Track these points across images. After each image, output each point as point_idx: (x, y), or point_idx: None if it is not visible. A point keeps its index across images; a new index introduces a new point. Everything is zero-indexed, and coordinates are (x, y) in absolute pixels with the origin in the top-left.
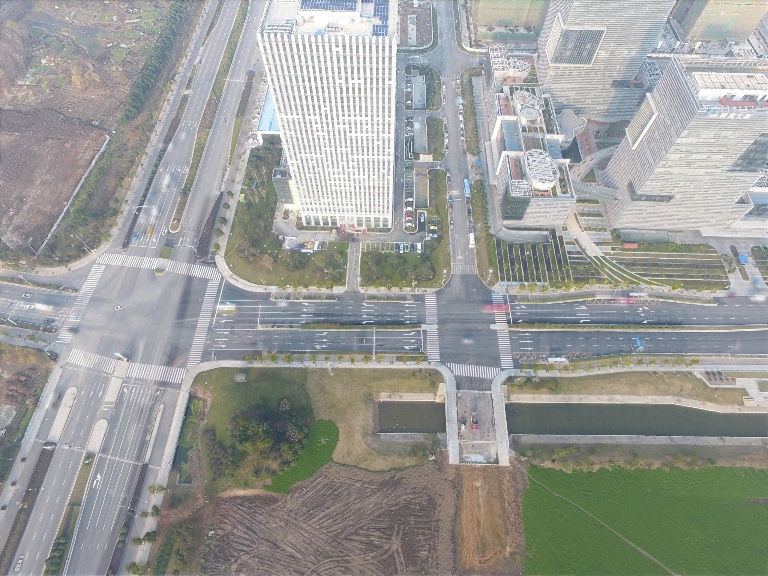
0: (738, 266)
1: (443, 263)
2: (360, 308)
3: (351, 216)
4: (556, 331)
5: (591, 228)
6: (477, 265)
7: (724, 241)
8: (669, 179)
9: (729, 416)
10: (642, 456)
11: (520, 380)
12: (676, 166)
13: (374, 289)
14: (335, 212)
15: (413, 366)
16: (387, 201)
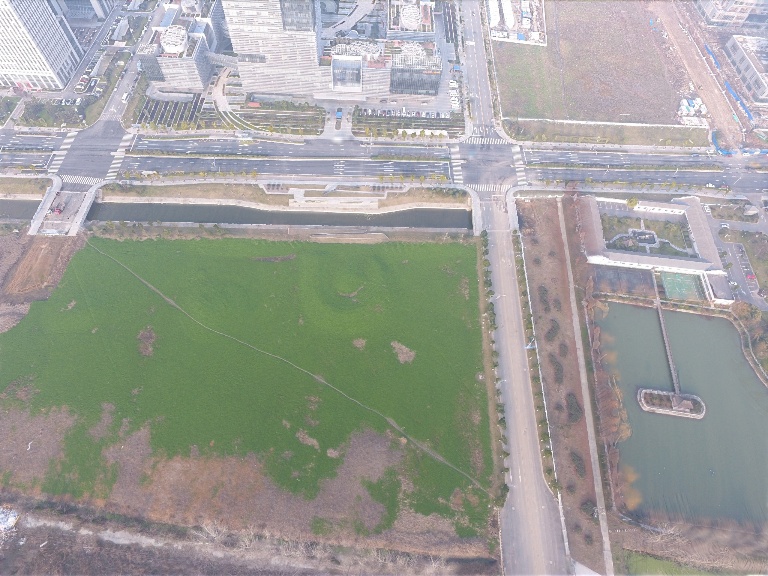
0: (336, 120)
1: (95, 113)
2: (8, 140)
3: (20, 74)
4: (164, 157)
5: (231, 93)
6: (123, 115)
7: (335, 105)
8: (246, 37)
9: (275, 213)
10: None
11: (113, 185)
12: (240, 22)
13: (27, 128)
14: (4, 69)
15: (32, 176)
16: (39, 57)
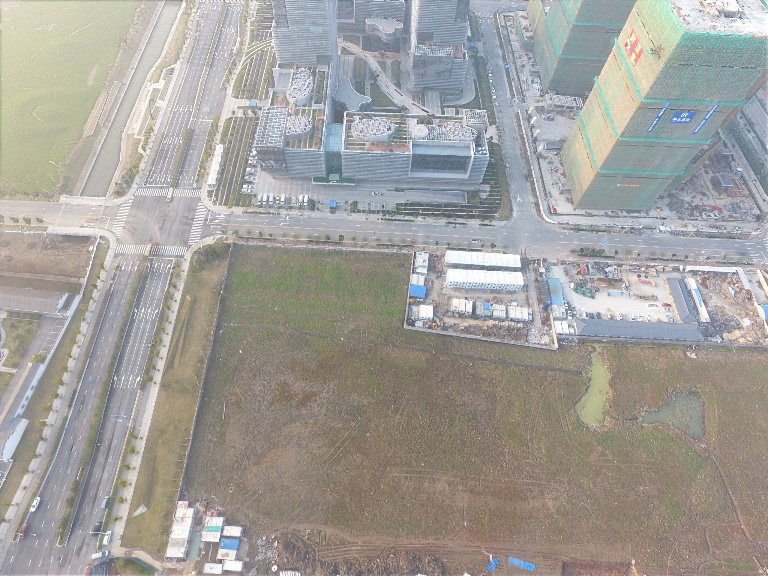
0: None
1: None
2: None
3: None
4: None
5: None
6: None
7: None
8: None
9: None
10: (131, 23)
11: None
12: None
13: None
14: None
15: None
16: None
